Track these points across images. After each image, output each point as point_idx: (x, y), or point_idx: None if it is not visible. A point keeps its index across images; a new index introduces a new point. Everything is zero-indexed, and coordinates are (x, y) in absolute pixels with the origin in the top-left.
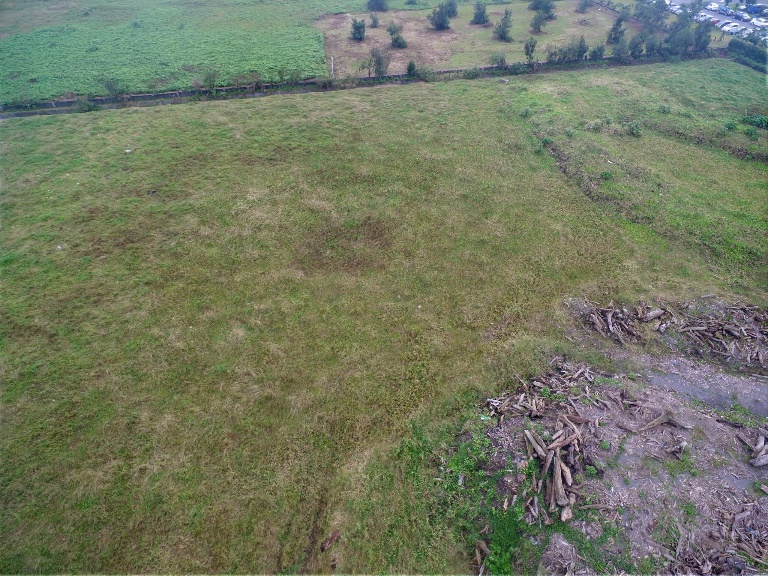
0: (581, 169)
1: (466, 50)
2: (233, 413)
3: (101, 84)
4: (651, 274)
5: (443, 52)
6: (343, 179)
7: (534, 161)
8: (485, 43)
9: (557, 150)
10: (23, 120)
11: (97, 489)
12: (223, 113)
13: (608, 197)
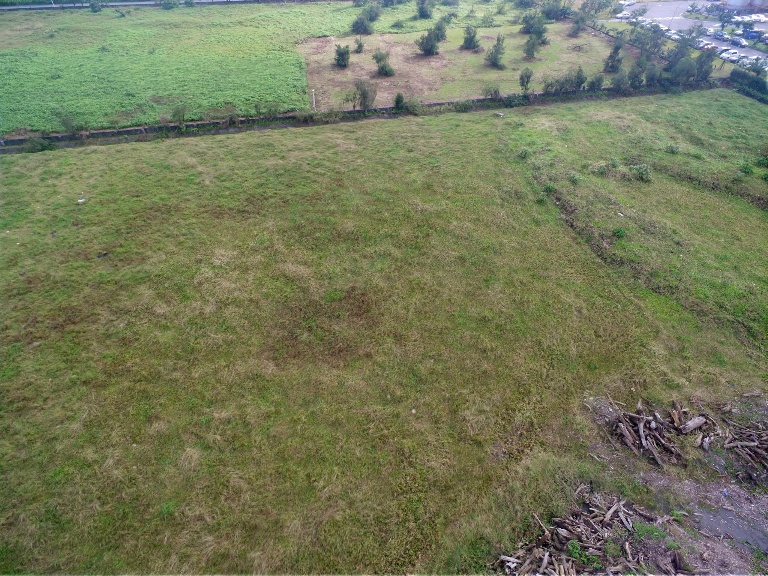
0: (590, 224)
1: (457, 79)
2: None
3: (59, 118)
4: (682, 362)
5: (433, 81)
6: (324, 236)
7: (537, 212)
8: (476, 71)
9: (562, 199)
10: None
11: None
12: (192, 153)
13: (623, 260)
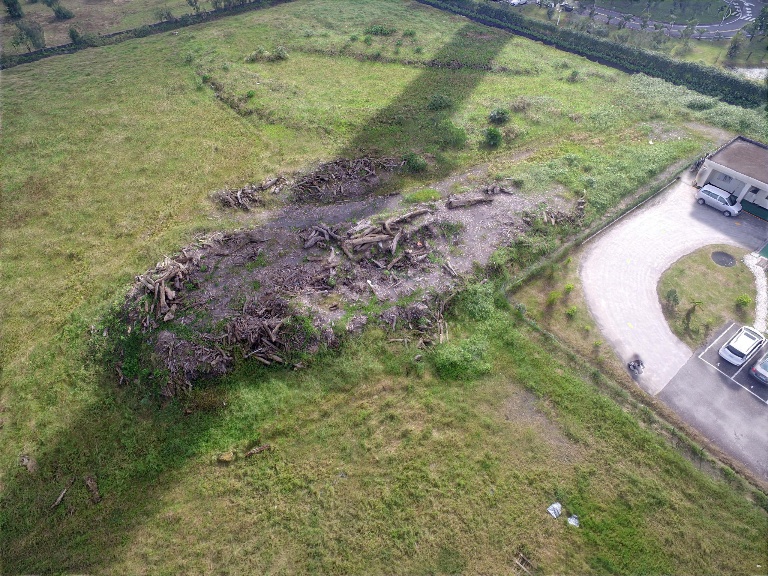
0: (232, 94)
1: (138, 11)
2: None
3: None
4: None
5: (114, 16)
6: (3, 152)
7: (196, 96)
8: (158, 1)
9: (215, 83)
10: None
11: None
12: None
13: (252, 110)
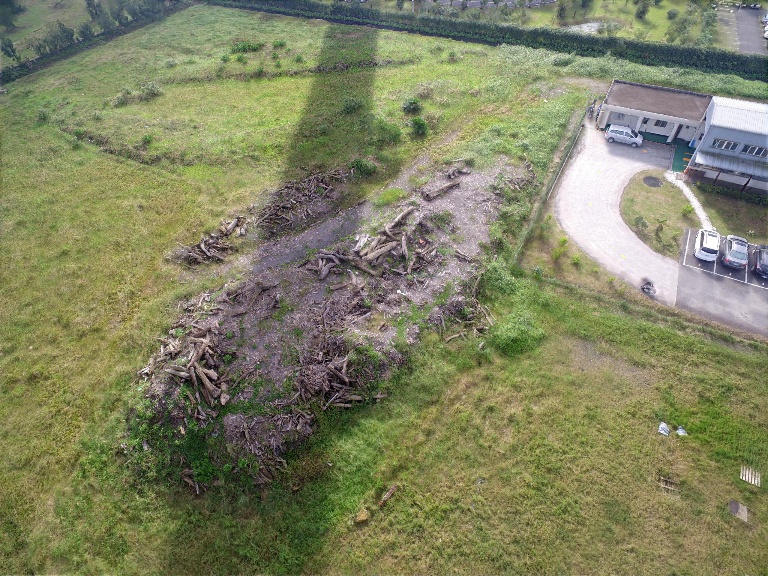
0: (124, 143)
1: None
2: None
3: None
4: (220, 198)
5: None
6: None
7: (77, 156)
8: None
9: (94, 137)
10: None
11: None
12: None
13: (158, 156)
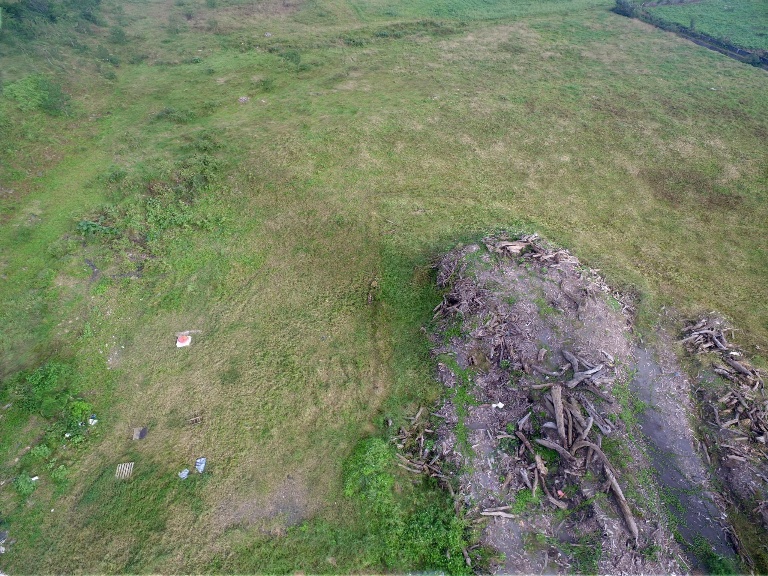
0: None
1: None
2: (513, 166)
3: None
4: None
5: None
6: None
7: None
8: None
9: None
10: (705, 50)
11: (463, 141)
12: None
13: None
